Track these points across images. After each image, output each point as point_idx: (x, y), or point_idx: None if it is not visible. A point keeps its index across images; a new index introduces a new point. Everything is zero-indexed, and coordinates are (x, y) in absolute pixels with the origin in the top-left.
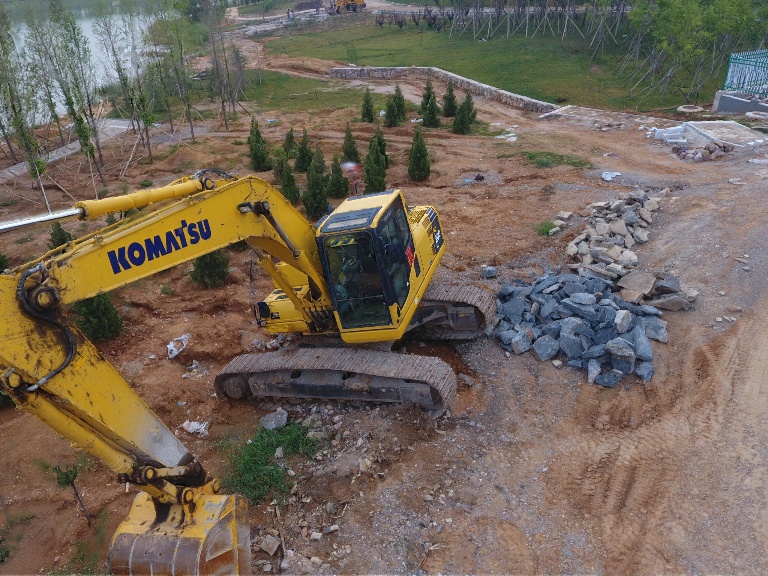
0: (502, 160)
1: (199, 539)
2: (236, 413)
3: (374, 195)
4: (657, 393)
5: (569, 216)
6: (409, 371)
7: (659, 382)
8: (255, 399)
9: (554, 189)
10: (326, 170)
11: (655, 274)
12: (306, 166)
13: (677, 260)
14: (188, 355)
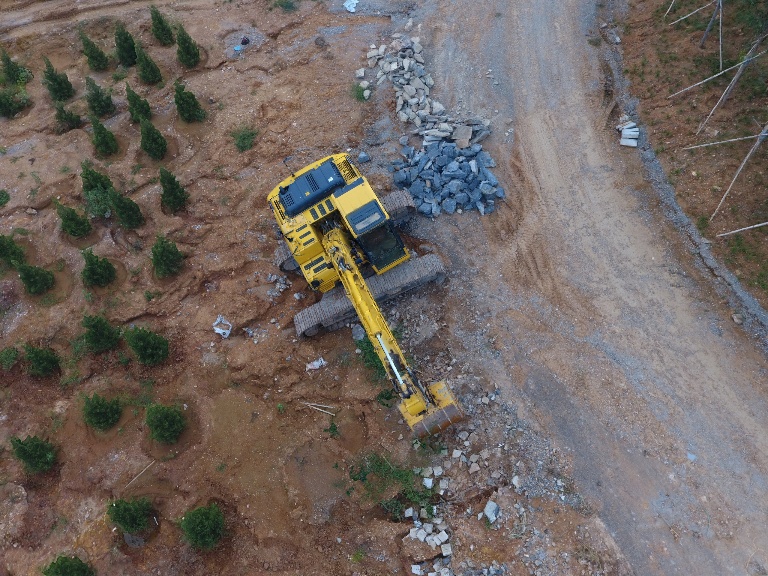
0: (239, 5)
1: (452, 404)
2: (325, 342)
3: (352, 188)
4: (513, 203)
5: (364, 73)
6: (424, 271)
7: (509, 196)
8: (324, 328)
9: (325, 40)
10: (105, 94)
11: (466, 121)
12: (68, 92)
13: (460, 94)
14: (237, 328)
